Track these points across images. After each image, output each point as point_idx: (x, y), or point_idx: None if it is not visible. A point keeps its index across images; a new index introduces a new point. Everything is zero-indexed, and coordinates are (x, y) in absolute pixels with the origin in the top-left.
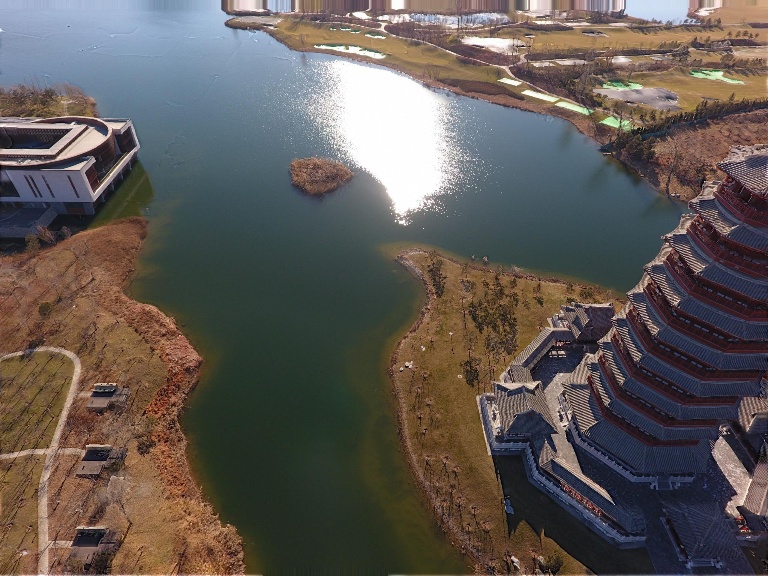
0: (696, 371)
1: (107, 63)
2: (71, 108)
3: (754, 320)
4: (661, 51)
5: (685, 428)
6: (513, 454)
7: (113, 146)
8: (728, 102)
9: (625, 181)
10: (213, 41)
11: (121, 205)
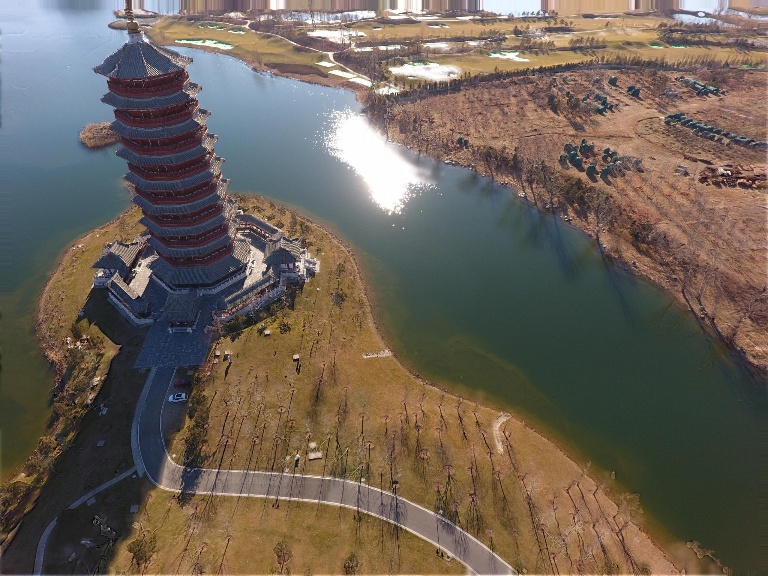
0: (148, 198)
1: None
2: None
3: (144, 154)
4: (482, 38)
5: (184, 249)
6: None
7: None
8: None
9: None
10: (86, 39)
11: None
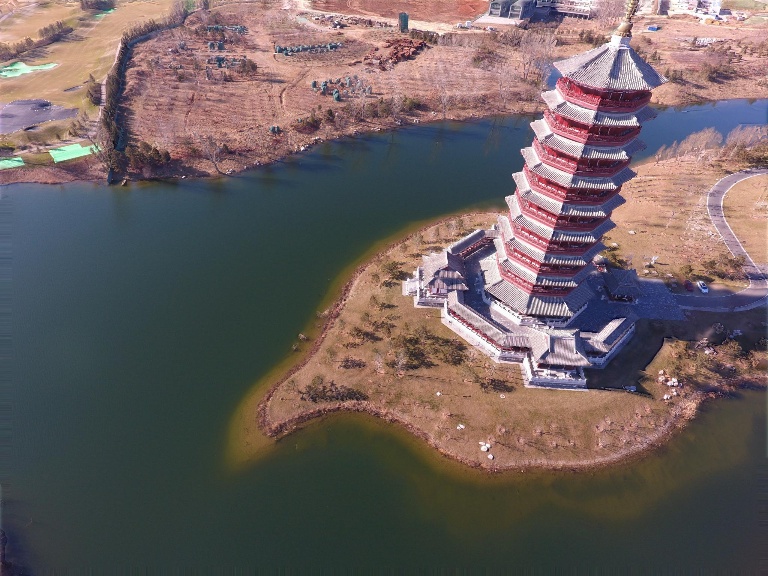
0: None
1: None
2: None
3: None
4: None
5: None
6: None
7: None
8: (93, 84)
9: (188, 190)
10: None
11: None
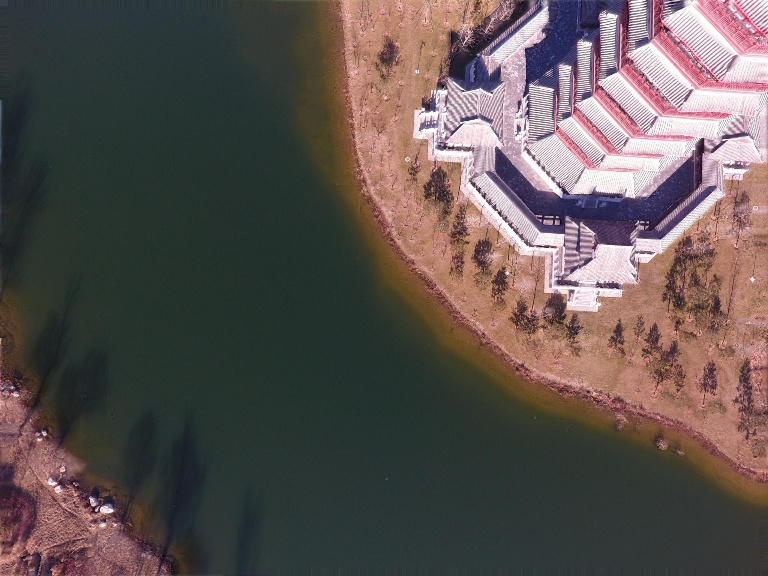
0: None
1: None
2: None
3: None
4: None
5: None
6: None
7: None
8: None
9: None
10: None
11: None
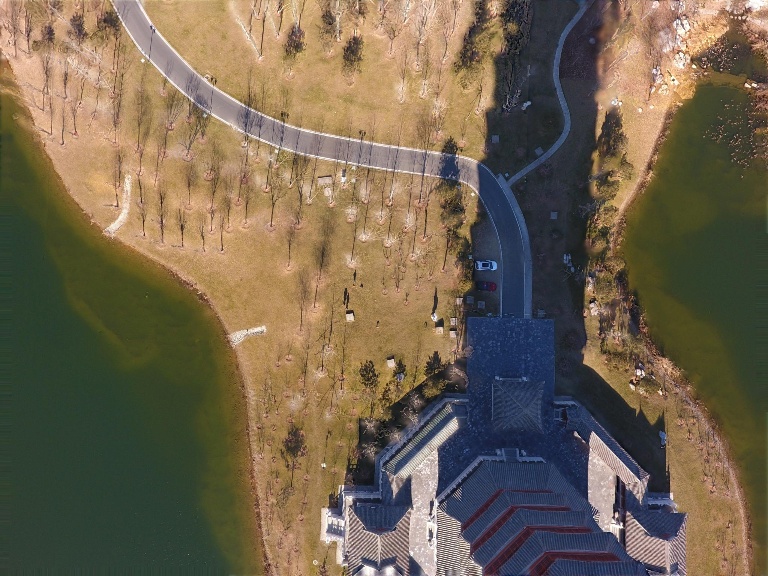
0: None
1: None
2: None
3: None
4: None
5: None
6: None
7: None
8: None
9: None
10: None
11: None
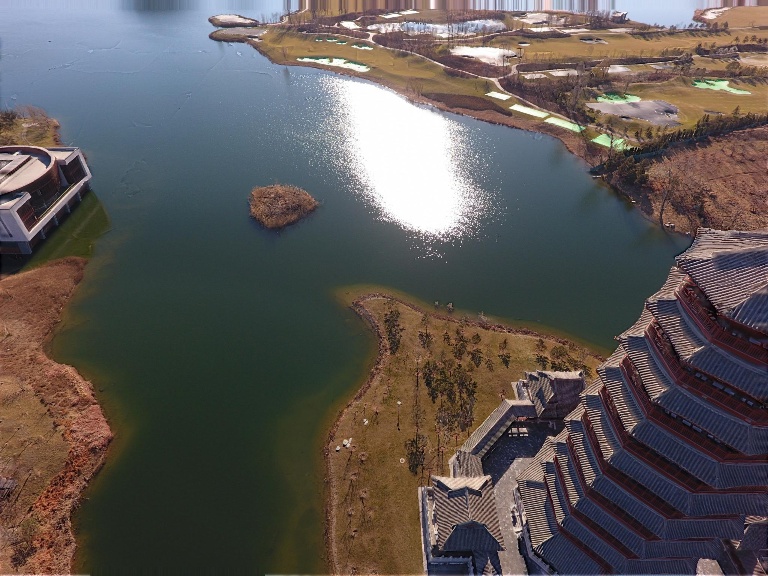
0: (660, 507)
1: (80, 81)
2: (30, 132)
3: (730, 461)
4: (663, 59)
5: (654, 559)
6: (453, 569)
7: (56, 178)
8: (732, 116)
9: (615, 209)
10: (193, 55)
11: (62, 242)
